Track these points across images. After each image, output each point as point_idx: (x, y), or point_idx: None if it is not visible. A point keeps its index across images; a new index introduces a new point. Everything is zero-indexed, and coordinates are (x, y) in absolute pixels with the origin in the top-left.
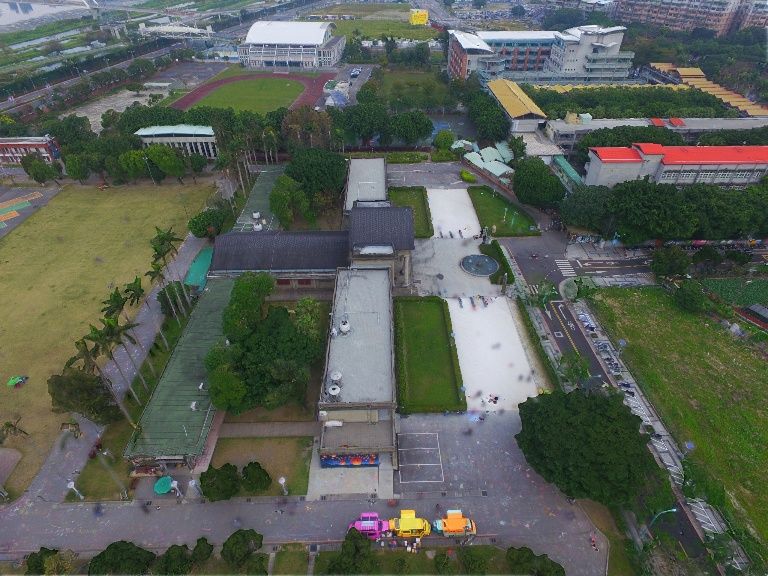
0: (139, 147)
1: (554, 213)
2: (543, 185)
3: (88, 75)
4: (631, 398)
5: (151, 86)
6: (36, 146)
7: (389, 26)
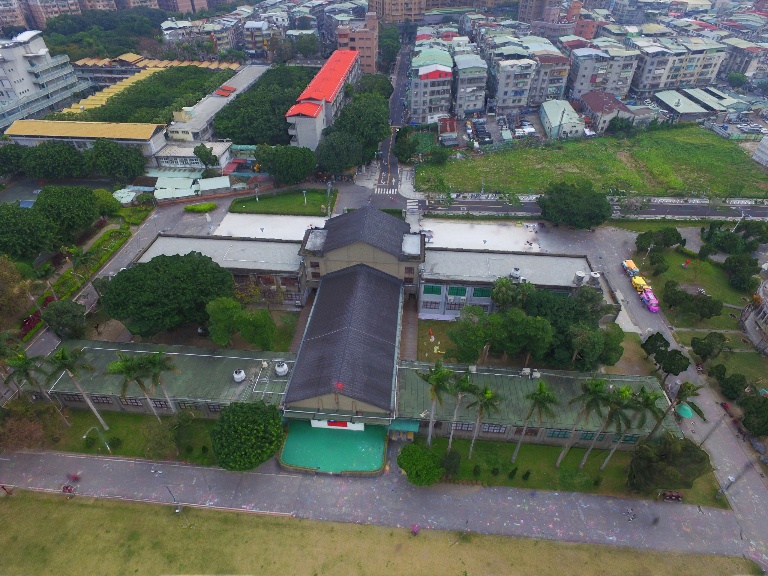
0: None
1: (307, 178)
2: (308, 156)
3: None
4: None
5: None
6: None
7: None
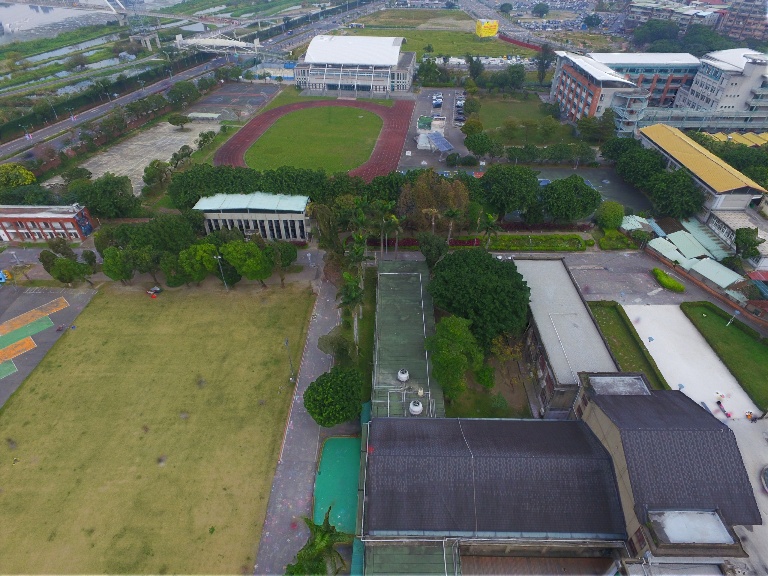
0: (201, 227)
1: None
2: None
3: (119, 99)
4: None
5: (197, 117)
6: (60, 221)
7: (452, 38)
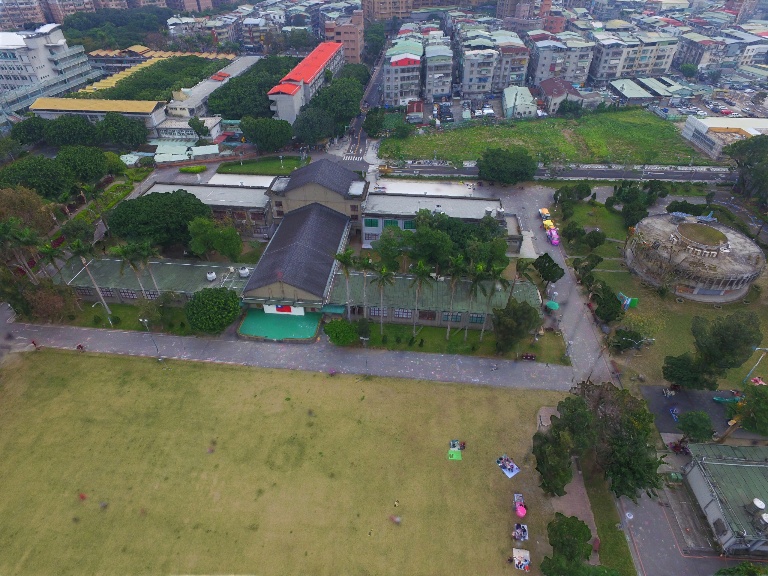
0: None
1: (286, 148)
2: (285, 126)
3: None
4: (464, 164)
5: None
6: None
7: None
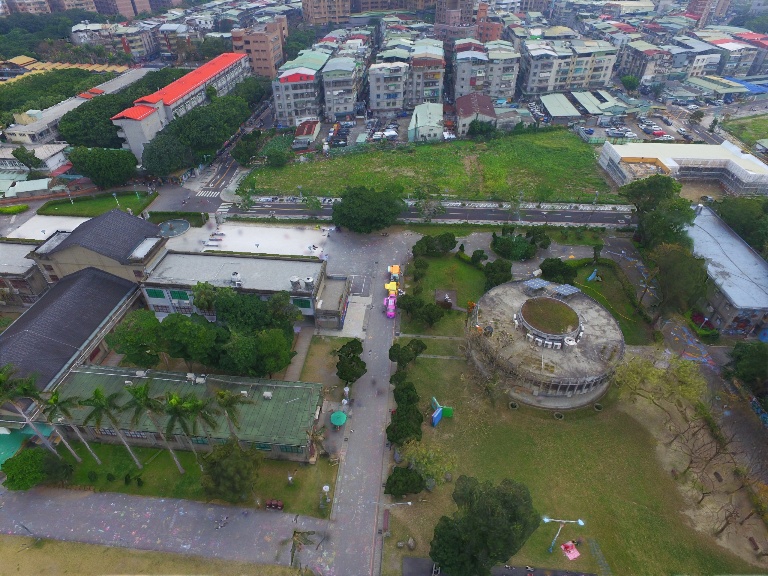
0: None
1: (136, 181)
2: (122, 158)
3: None
4: None
5: None
6: None
7: None
